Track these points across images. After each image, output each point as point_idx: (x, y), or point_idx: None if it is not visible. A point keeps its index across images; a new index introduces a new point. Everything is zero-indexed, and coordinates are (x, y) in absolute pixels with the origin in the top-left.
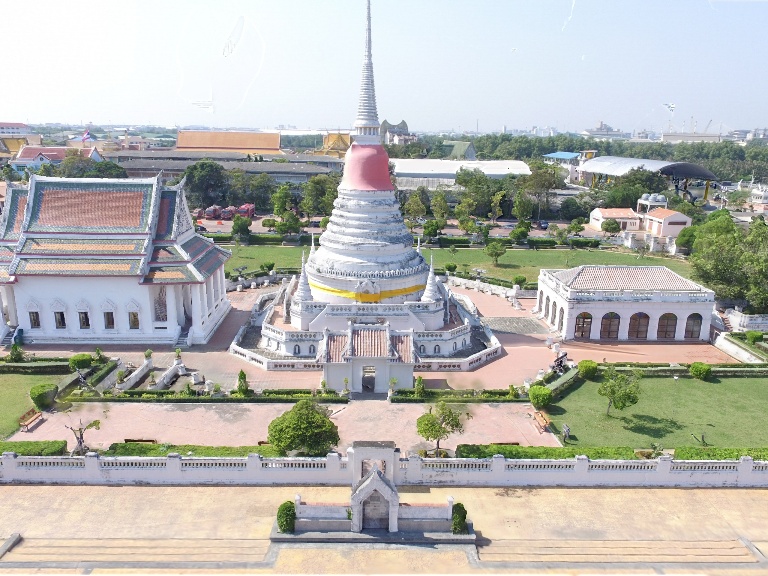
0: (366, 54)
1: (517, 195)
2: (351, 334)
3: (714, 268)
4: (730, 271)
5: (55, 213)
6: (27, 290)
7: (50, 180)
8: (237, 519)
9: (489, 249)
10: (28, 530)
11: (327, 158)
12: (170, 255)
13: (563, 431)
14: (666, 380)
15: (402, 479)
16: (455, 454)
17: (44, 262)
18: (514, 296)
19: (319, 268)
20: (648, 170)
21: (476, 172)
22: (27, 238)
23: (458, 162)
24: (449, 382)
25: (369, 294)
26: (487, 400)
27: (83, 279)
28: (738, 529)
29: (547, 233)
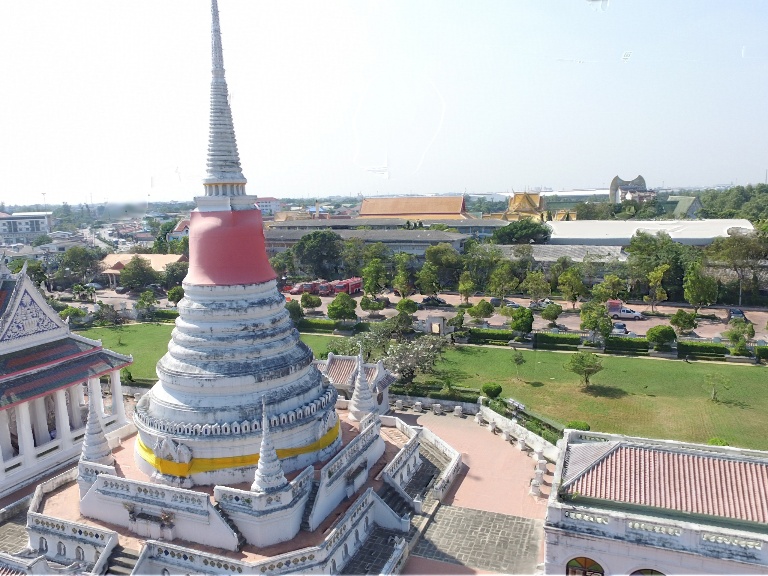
0: (211, 70)
1: (688, 271)
2: None
3: None
4: None
5: None
6: None
7: None
8: None
9: (570, 362)
10: None
11: (495, 222)
12: None
13: None
14: None
15: None
16: None
17: None
18: None
19: None
20: None
21: (660, 236)
22: None
23: (647, 223)
24: None
25: (172, 462)
26: None
27: None
28: None
29: (726, 331)
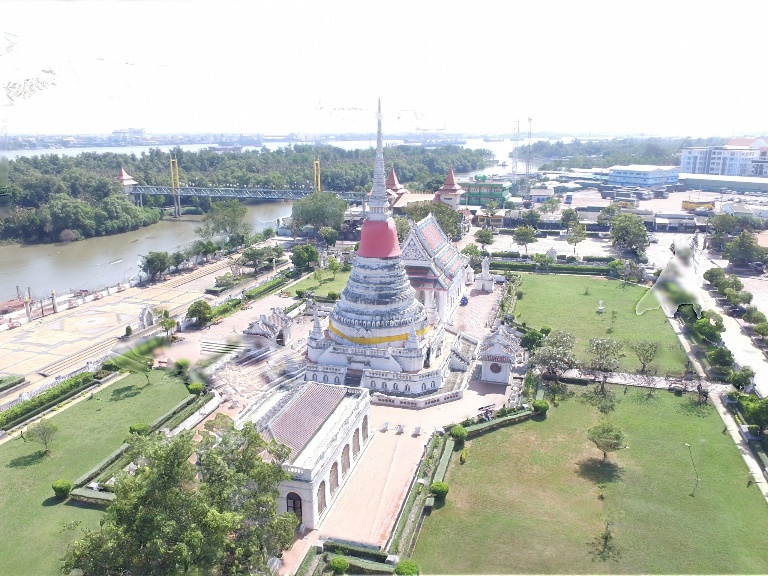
0: None
1: None
2: None
3: None
4: None
5: None
6: None
7: None
8: None
9: None
10: (215, 300)
11: None
12: None
13: None
14: None
15: None
16: None
17: None
18: None
19: None
20: None
21: None
22: None
23: None
24: None
25: None
26: None
27: None
28: (52, 378)
29: None
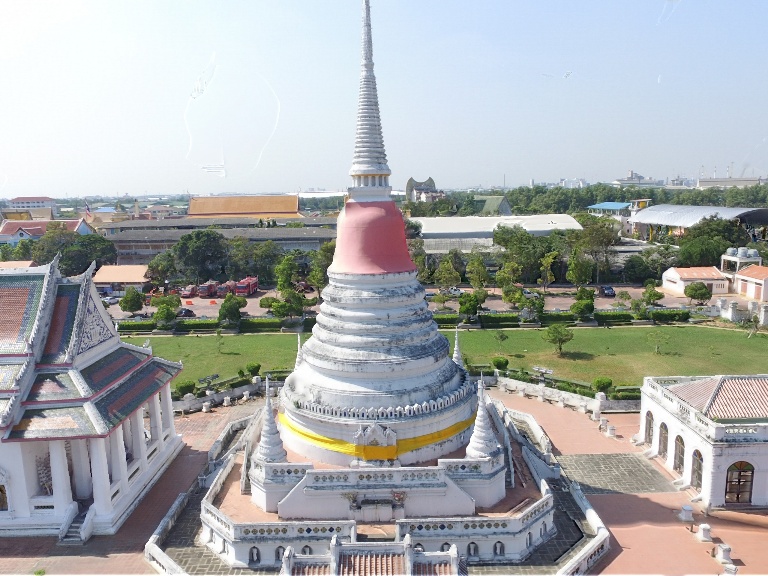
0: (363, 63)
1: (572, 256)
2: (335, 566)
3: None
4: None
5: None
6: None
7: None
8: None
9: (550, 334)
10: None
11: None
12: (59, 388)
13: None
14: None
15: None
16: None
17: None
18: (599, 411)
19: (297, 401)
20: (724, 219)
21: (516, 229)
22: None
23: (494, 218)
24: None
25: (378, 447)
26: None
27: None
28: None
29: (616, 303)
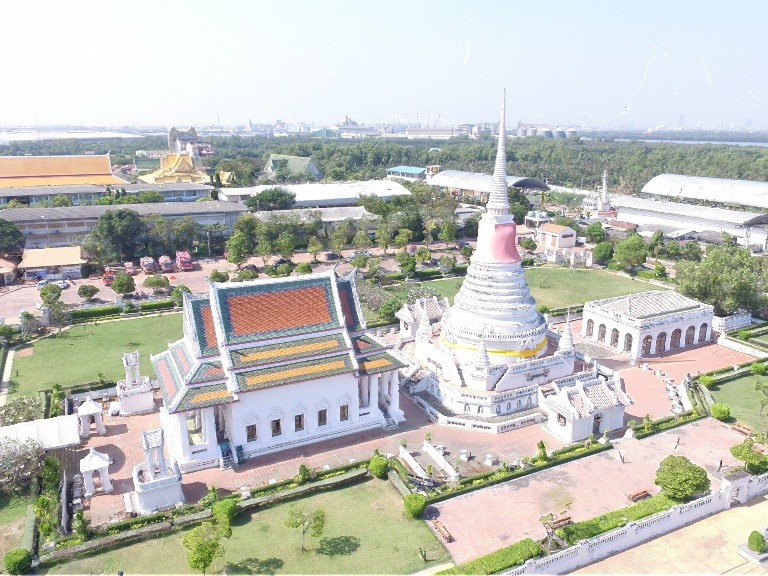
0: (502, 147)
1: (446, 222)
2: (584, 391)
3: (697, 287)
4: (705, 287)
5: (247, 320)
6: (247, 405)
7: (232, 286)
8: (710, 556)
9: None
10: None
11: (194, 186)
12: (368, 344)
13: (761, 434)
14: (745, 380)
15: (747, 495)
16: (742, 468)
17: (261, 373)
18: None
19: (481, 334)
20: (513, 188)
21: (373, 197)
22: (230, 351)
23: (341, 186)
24: (627, 412)
25: (529, 350)
26: (686, 422)
27: (302, 383)
28: None
29: None
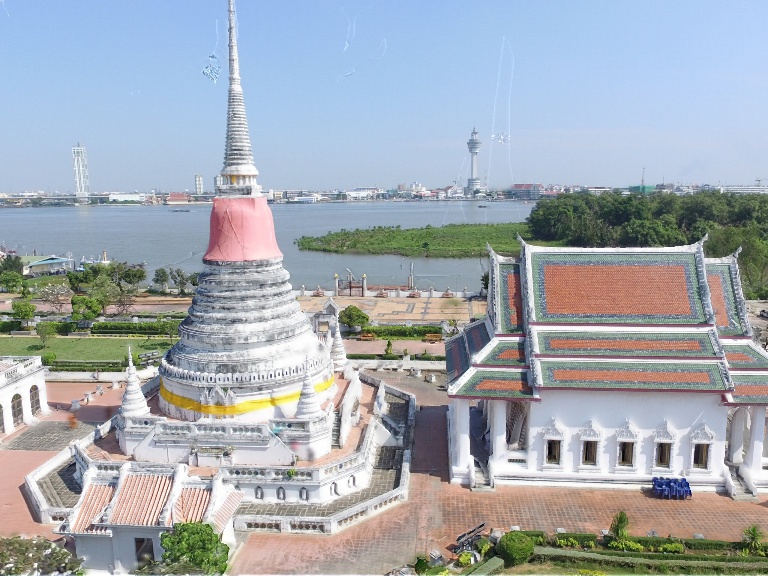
0: None
1: None
2: None
3: None
4: None
5: None
6: None
7: None
8: None
9: None
10: None
11: None
12: None
13: None
14: None
15: None
16: None
17: None
18: None
19: None
20: None
21: None
22: None
23: None
24: None
25: None
26: None
27: None
28: None
29: None
